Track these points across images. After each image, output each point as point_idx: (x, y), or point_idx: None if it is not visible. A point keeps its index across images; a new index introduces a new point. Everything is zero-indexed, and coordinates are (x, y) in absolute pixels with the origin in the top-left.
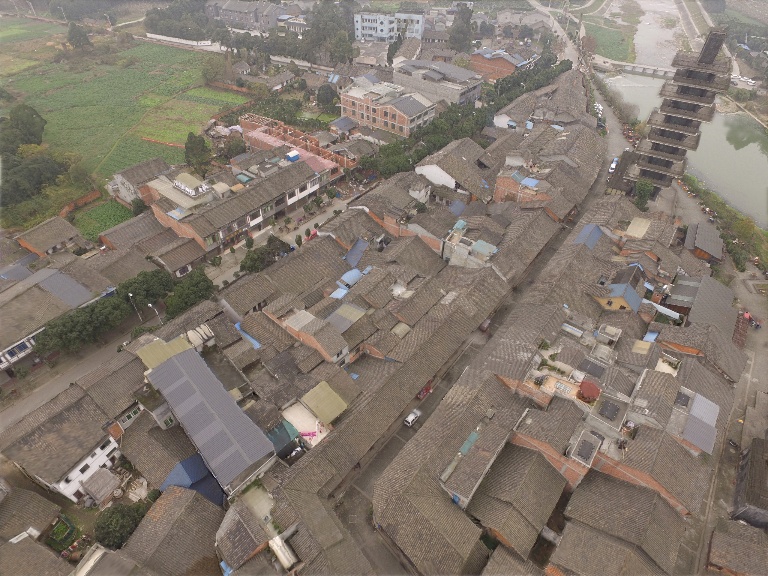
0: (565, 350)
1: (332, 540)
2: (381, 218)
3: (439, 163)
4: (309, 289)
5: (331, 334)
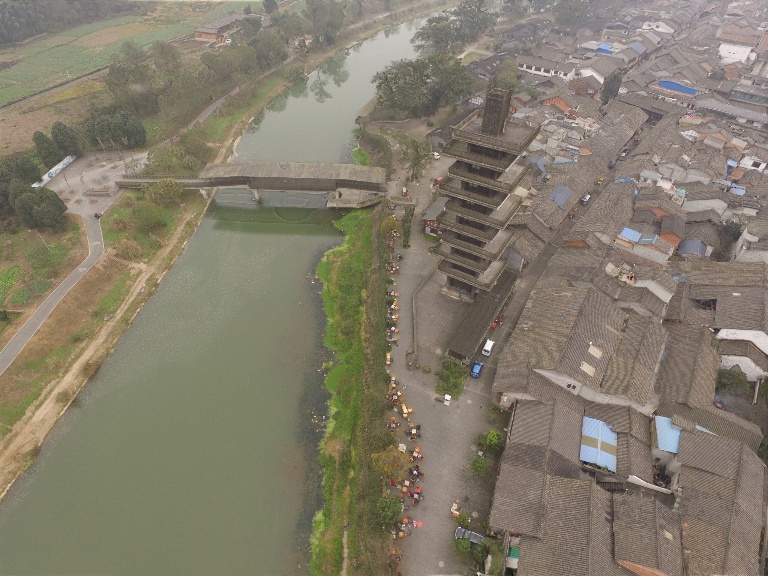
0: (581, 132)
1: (656, 103)
2: (760, 208)
3: (762, 264)
4: (759, 179)
5: (713, 131)
